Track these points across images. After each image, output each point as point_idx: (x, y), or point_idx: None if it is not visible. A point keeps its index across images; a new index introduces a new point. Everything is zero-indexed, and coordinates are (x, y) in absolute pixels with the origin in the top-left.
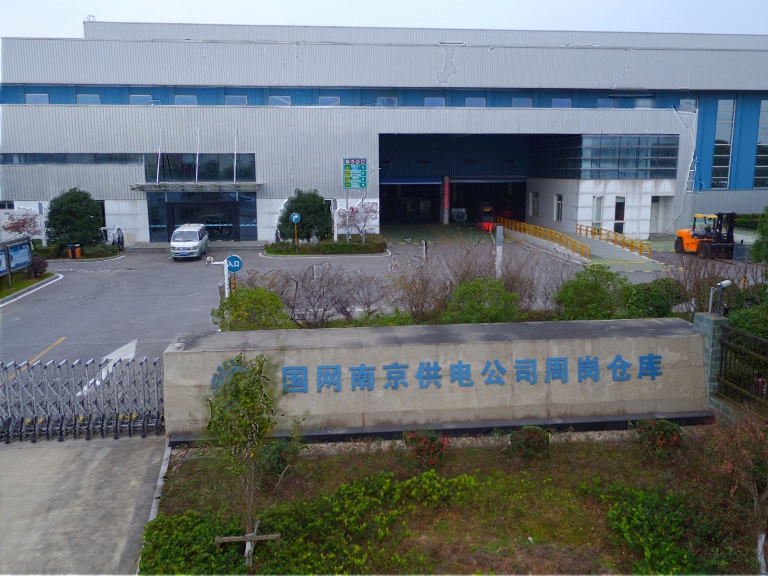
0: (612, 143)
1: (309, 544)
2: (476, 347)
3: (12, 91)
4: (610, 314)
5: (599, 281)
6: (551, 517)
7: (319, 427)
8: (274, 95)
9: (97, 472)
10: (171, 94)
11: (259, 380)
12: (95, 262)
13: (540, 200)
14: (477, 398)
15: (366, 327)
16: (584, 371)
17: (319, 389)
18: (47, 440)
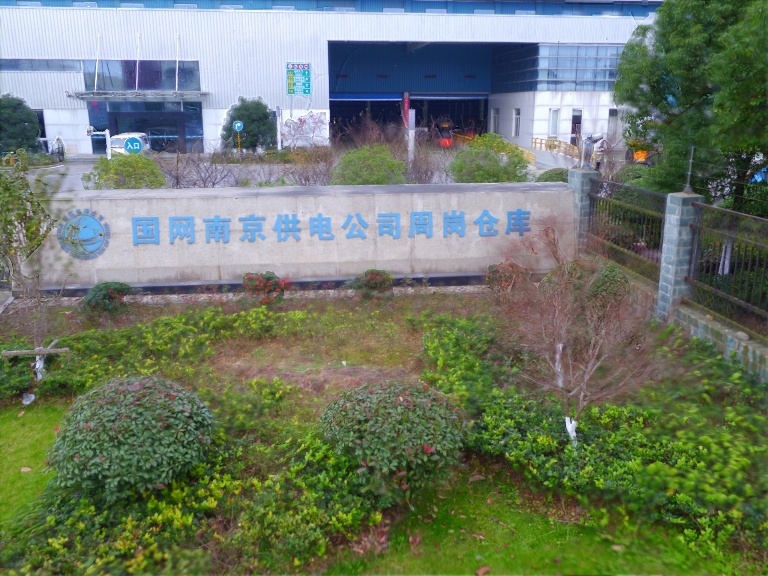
0: (570, 53)
1: None
2: (337, 200)
3: None
4: (497, 181)
5: (489, 149)
6: (371, 344)
7: (99, 233)
8: (225, 4)
9: None
10: (117, 2)
11: (25, 178)
12: (30, 170)
13: (500, 116)
14: (338, 252)
15: (235, 187)
16: (450, 226)
17: (172, 241)
18: None
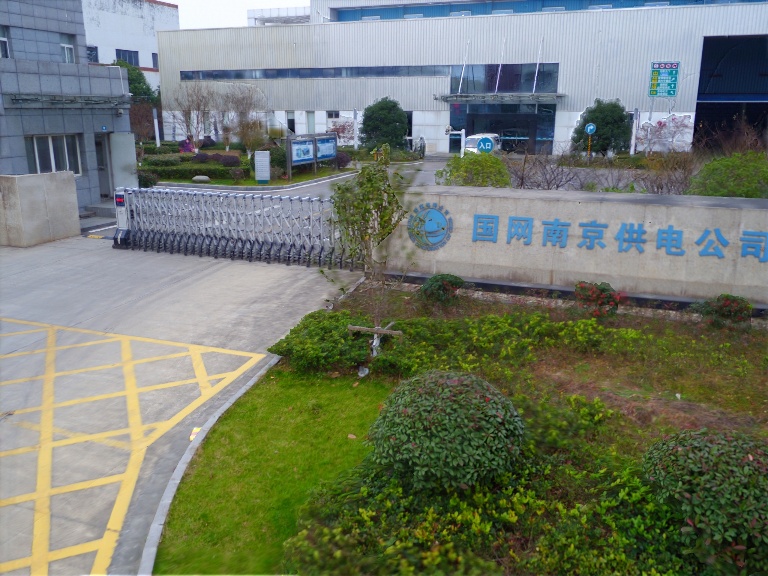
0: None
1: (429, 347)
2: (693, 212)
3: (352, 15)
4: None
5: None
6: (714, 381)
7: (442, 227)
8: (594, 4)
9: (302, 286)
10: (489, 9)
11: (385, 171)
12: (395, 165)
13: None
14: (686, 270)
15: (580, 191)
16: None
17: (509, 240)
18: (278, 263)
